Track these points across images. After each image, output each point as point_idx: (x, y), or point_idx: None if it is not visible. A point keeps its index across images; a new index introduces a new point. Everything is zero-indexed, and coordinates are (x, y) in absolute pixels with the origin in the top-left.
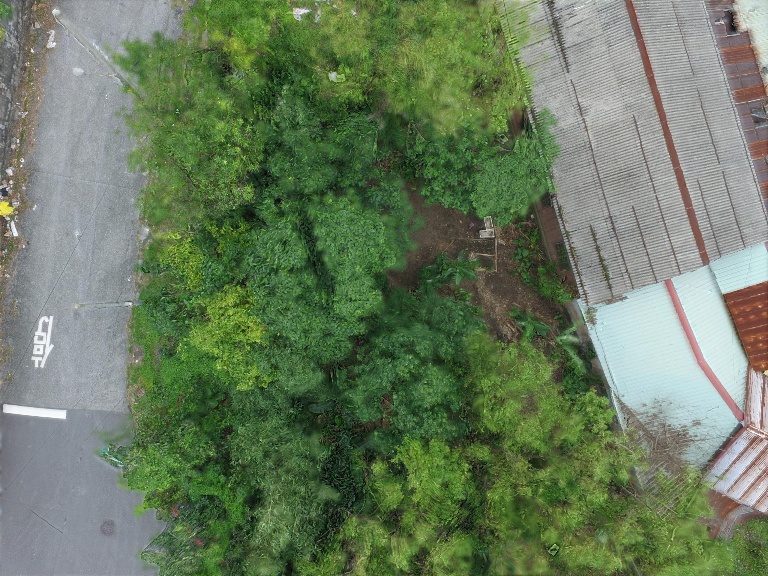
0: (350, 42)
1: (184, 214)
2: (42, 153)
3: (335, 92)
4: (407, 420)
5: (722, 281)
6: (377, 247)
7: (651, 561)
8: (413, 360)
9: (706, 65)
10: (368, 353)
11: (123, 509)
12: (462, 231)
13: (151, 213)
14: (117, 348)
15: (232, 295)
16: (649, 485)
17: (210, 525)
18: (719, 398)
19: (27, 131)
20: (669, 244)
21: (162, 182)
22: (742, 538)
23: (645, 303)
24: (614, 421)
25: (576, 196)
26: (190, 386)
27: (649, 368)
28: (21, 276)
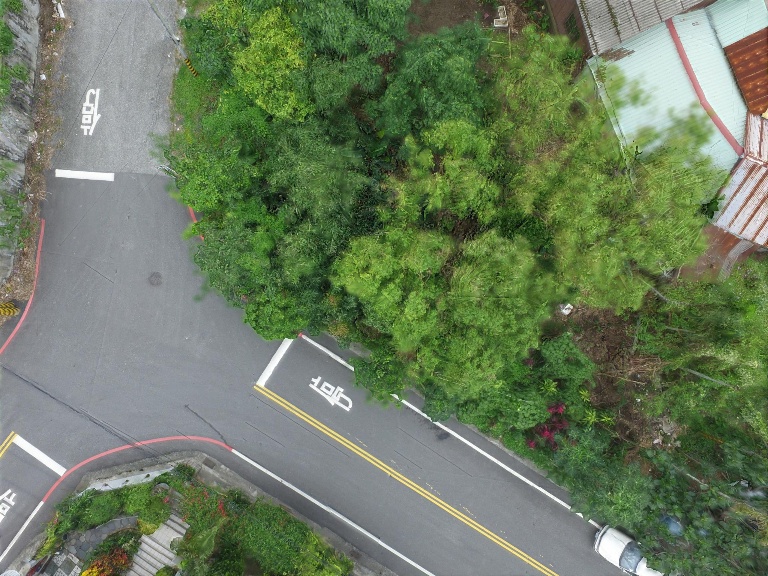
0: None
1: None
2: None
3: None
4: (437, 108)
5: (722, 35)
6: None
7: (659, 297)
8: (441, 52)
9: None
10: (397, 76)
11: (169, 263)
12: None
13: None
14: (159, 118)
15: (273, 14)
16: None
17: (256, 233)
18: (720, 136)
19: None
20: None
21: None
22: (743, 277)
23: (651, 54)
24: None
25: None
26: (231, 134)
27: (655, 115)
28: (68, 53)
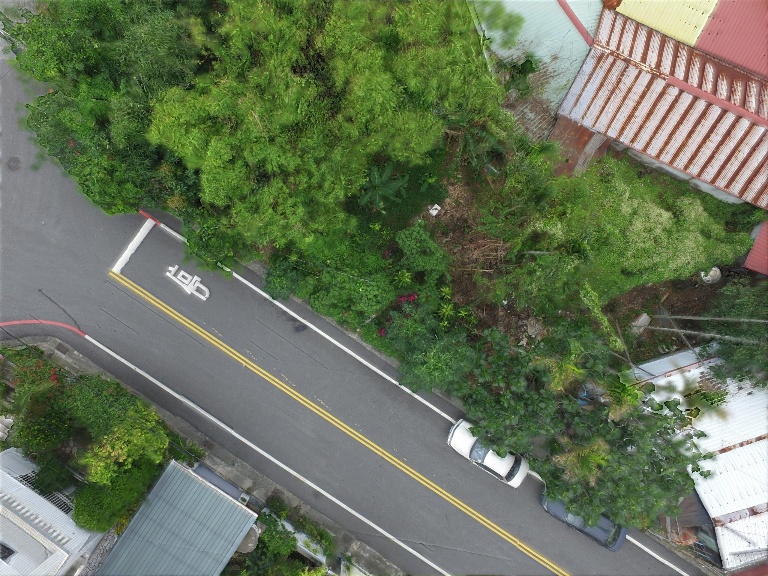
0: None
1: None
2: None
3: None
4: None
5: None
6: None
7: None
8: None
9: None
10: None
11: (28, 148)
12: None
13: None
14: (25, 6)
15: None
16: (515, 126)
17: None
18: (572, 27)
19: None
20: None
21: None
22: (600, 173)
23: None
24: (485, 71)
25: None
26: (86, 15)
27: (512, 8)
28: None
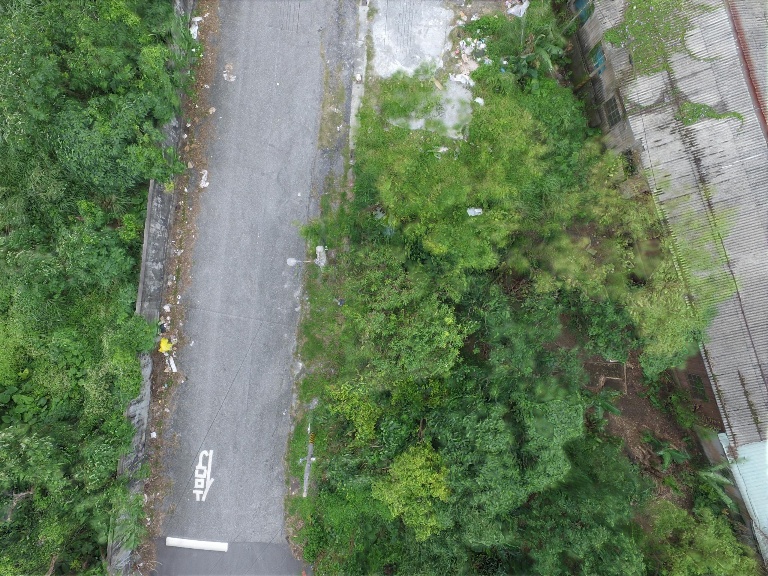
0: (491, 182)
1: (334, 348)
2: (198, 290)
3: (475, 228)
4: None
5: None
6: (576, 427)
7: None
8: (606, 531)
9: None
10: (544, 508)
11: None
12: None
13: (304, 348)
14: (274, 481)
15: (421, 459)
16: None
17: None
18: None
19: (183, 269)
20: None
21: (313, 317)
22: None
23: None
24: (754, 550)
25: (723, 342)
26: (357, 527)
27: None
28: (181, 411)
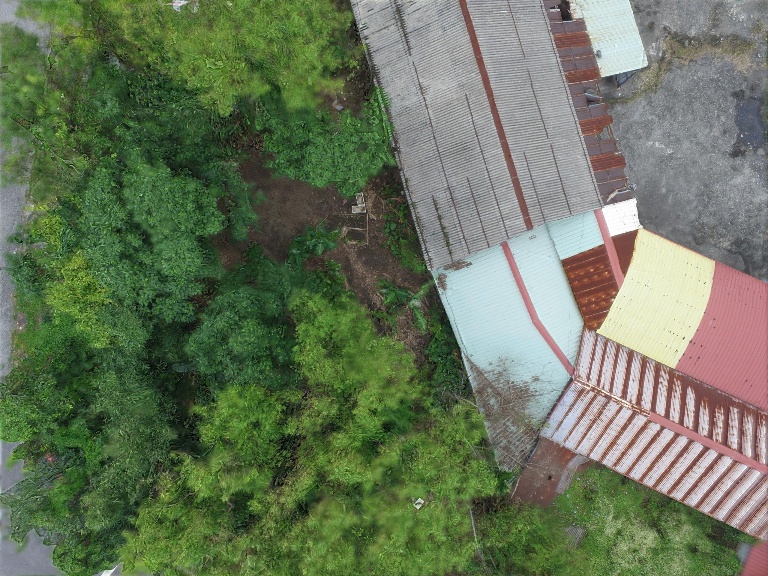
0: (223, 30)
1: None
2: None
3: None
4: (234, 368)
5: (560, 248)
6: (202, 209)
7: (497, 509)
8: (239, 313)
9: (539, 48)
10: (214, 312)
11: (6, 466)
12: (336, 207)
13: (36, 190)
14: (2, 316)
15: (83, 258)
16: (497, 439)
17: (66, 471)
18: (553, 355)
19: None
20: (498, 211)
21: (47, 161)
22: (583, 487)
23: (487, 268)
24: (466, 380)
25: (420, 169)
26: (62, 348)
27: (492, 328)
28: None
